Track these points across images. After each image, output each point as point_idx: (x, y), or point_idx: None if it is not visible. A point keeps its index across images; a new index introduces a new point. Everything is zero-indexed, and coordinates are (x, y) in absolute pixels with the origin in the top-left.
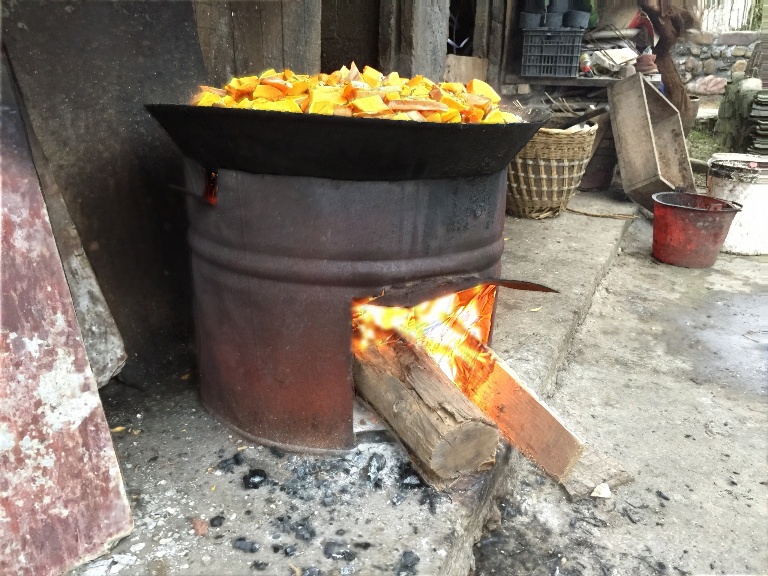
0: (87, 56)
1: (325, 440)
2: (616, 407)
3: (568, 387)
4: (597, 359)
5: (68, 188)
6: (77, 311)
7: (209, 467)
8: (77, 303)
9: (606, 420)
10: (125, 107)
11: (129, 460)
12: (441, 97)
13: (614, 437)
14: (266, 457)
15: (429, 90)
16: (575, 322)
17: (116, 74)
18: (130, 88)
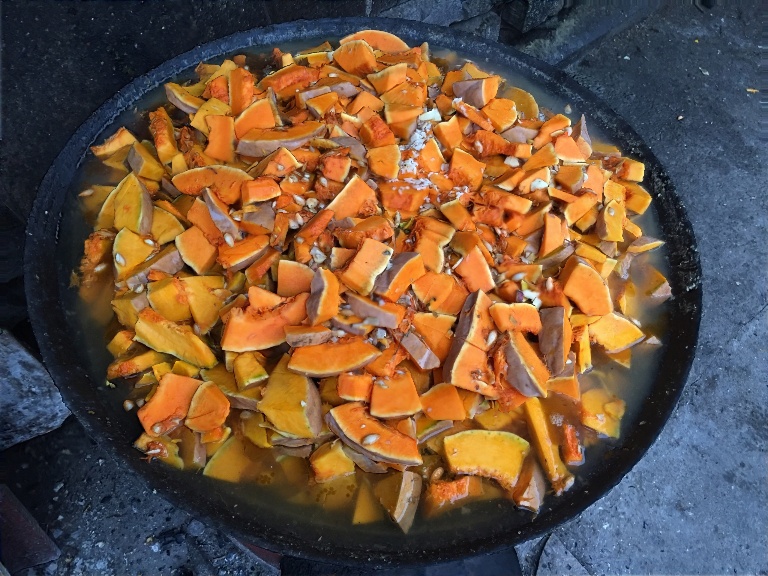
0: (2, 2)
1: (263, 560)
2: (686, 516)
3: (646, 459)
4: (726, 404)
5: (14, 181)
6: (9, 379)
7: (150, 535)
8: (7, 372)
9: (657, 538)
10: (90, 49)
11: (85, 491)
12: (447, 381)
13: (646, 575)
14: (209, 538)
15: (487, 261)
16: (731, 338)
17: (64, 8)
18: (94, 19)
